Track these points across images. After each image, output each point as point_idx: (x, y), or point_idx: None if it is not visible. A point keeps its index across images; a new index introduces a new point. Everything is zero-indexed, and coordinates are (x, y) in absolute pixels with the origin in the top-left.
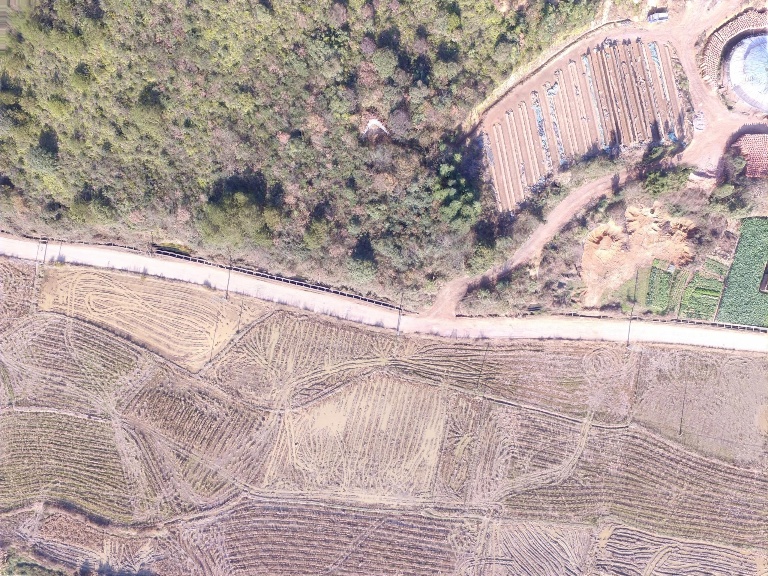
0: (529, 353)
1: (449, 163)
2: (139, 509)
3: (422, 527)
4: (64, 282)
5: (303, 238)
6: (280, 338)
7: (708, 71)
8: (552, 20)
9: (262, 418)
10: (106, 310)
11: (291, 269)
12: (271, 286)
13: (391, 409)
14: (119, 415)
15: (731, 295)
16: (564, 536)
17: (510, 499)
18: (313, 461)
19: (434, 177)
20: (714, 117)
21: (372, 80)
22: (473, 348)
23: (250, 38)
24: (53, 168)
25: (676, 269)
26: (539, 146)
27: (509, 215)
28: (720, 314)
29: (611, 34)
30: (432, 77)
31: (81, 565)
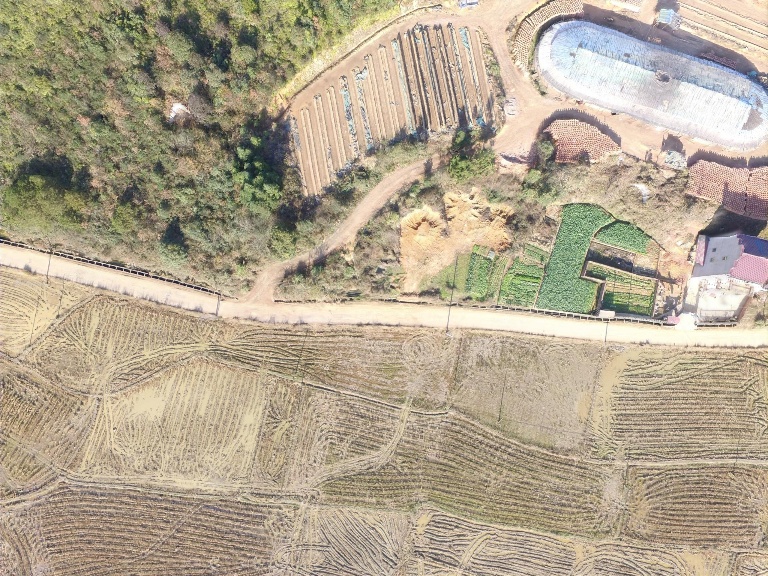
0: (349, 339)
1: (245, 146)
2: None
3: (239, 513)
4: None
5: None
6: (100, 323)
7: (518, 56)
8: (346, 4)
9: (81, 403)
10: None
11: (104, 253)
12: (91, 271)
13: (210, 394)
14: None
15: (551, 281)
16: (382, 522)
17: (328, 485)
18: (131, 446)
19: (232, 160)
20: (526, 102)
21: (168, 63)
22: (293, 334)
23: (41, 21)
24: None
25: (496, 255)
26: (346, 131)
27: (314, 199)
28: (539, 300)
29: (422, 19)
30: (230, 61)
31: None
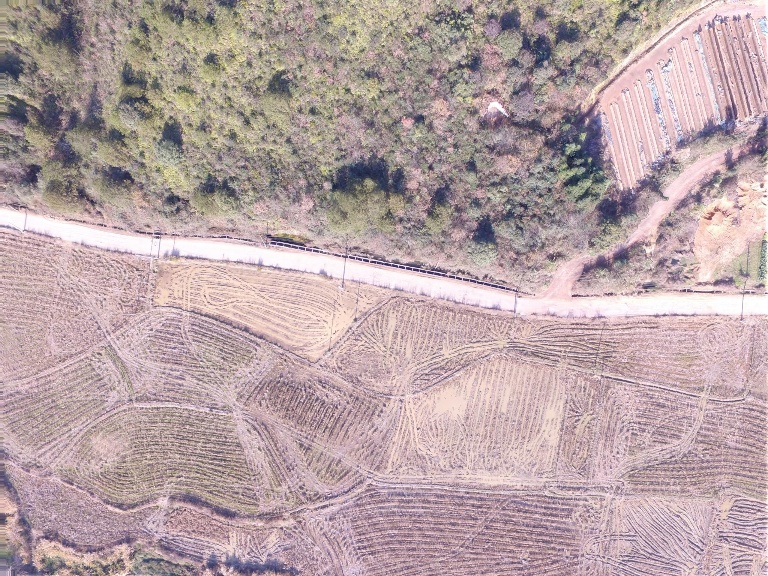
0: (645, 330)
1: (575, 142)
2: (264, 500)
3: (546, 506)
4: (179, 276)
5: (425, 223)
6: (397, 324)
7: None
8: None
9: (383, 405)
10: (222, 303)
11: (411, 255)
12: (387, 273)
13: (511, 391)
14: (240, 407)
15: None
16: (686, 510)
17: (632, 475)
18: (436, 445)
19: (560, 157)
20: None
21: (497, 62)
22: (589, 327)
23: (377, 24)
24: (178, 161)
25: None
26: (656, 124)
27: (630, 193)
28: None
29: (721, 10)
30: (554, 58)
31: (207, 558)
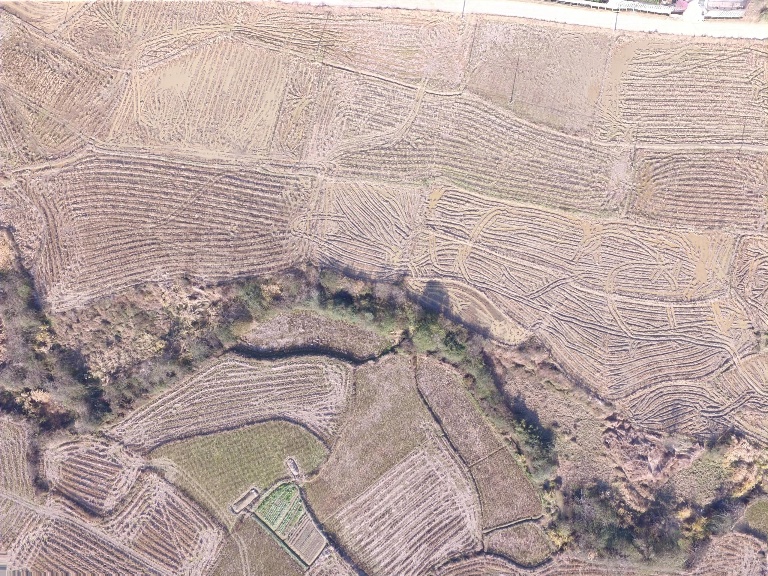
0: (368, 23)
1: None
2: None
3: (258, 183)
4: None
5: None
6: (132, 4)
7: None
8: None
9: (110, 77)
10: None
11: None
12: None
13: (234, 72)
14: None
15: None
16: (395, 196)
17: (344, 159)
18: (157, 118)
19: None
20: None
21: None
22: (314, 17)
23: None
24: None
25: None
26: None
27: None
28: None
29: None
30: None
31: None
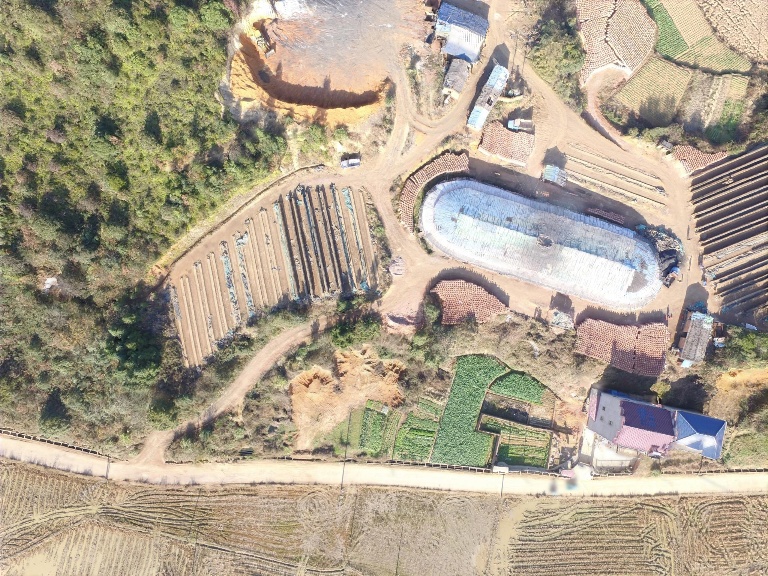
0: (242, 498)
1: (118, 326)
2: None
3: None
4: None
5: None
6: None
7: (403, 217)
8: (215, 181)
9: None
10: None
11: None
12: None
13: (102, 558)
14: None
15: (445, 435)
16: None
17: None
18: None
19: None
20: (413, 262)
21: (35, 244)
22: (185, 494)
23: None
24: None
25: (390, 410)
26: (228, 298)
27: (195, 371)
28: (434, 455)
29: (304, 180)
30: (101, 238)
31: None
